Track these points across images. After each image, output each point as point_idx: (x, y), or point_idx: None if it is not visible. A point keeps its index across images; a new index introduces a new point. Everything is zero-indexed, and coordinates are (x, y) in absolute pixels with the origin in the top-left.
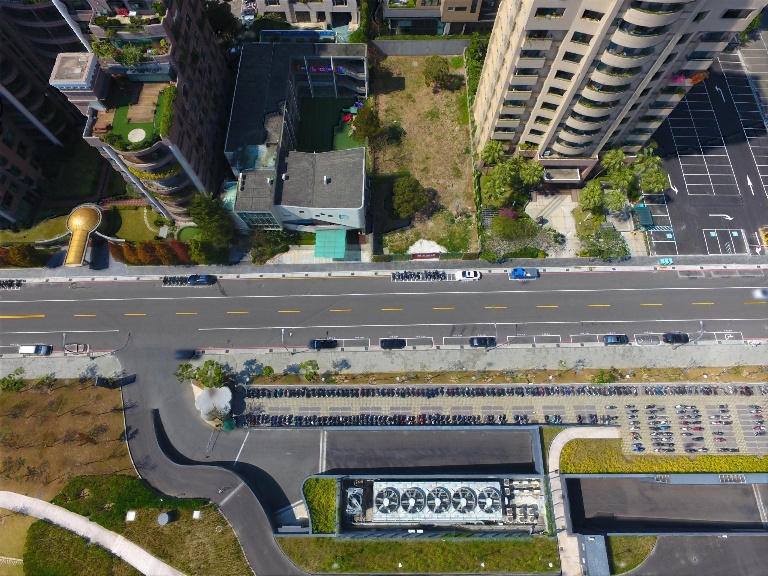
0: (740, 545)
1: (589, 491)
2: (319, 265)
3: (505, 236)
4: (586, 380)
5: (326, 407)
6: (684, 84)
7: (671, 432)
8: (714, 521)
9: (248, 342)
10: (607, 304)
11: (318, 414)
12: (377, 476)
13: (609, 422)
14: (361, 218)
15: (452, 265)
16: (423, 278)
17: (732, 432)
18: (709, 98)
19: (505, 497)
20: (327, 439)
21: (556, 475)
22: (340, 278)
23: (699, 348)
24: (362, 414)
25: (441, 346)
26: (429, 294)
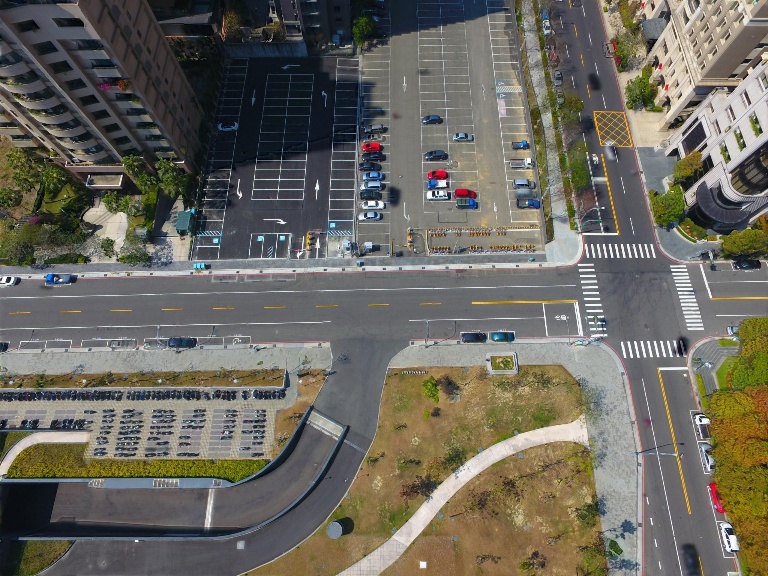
0: (154, 550)
1: (62, 495)
2: None
3: None
4: (73, 385)
5: None
6: (123, 91)
7: (139, 436)
8: (160, 526)
9: None
10: (129, 309)
11: None
12: None
13: (82, 427)
14: None
15: None
16: None
17: (199, 436)
18: (311, 103)
19: None
20: None
21: None
22: None
23: (202, 352)
24: None
25: None
26: None
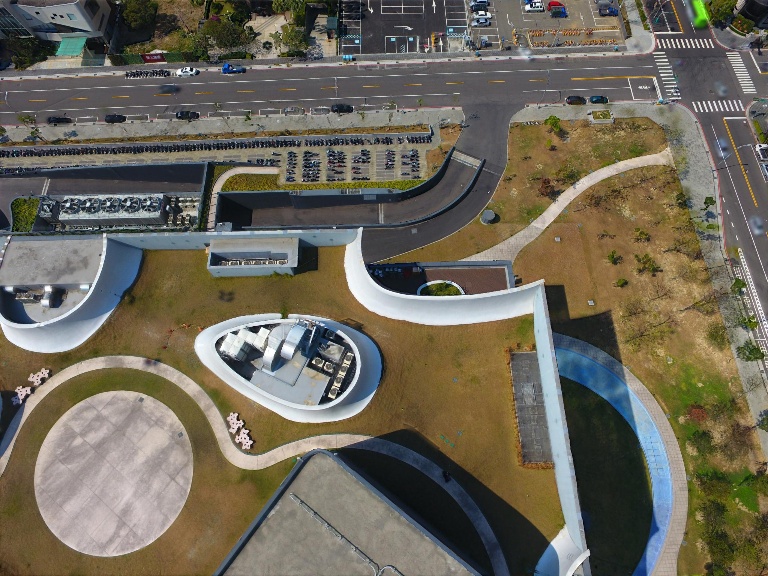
0: None
1: (257, 219)
2: (69, 69)
3: (211, 36)
4: (260, 136)
5: (52, 162)
6: None
7: (319, 169)
8: None
9: (0, 122)
10: (294, 88)
11: (45, 167)
12: (72, 195)
13: (272, 164)
14: (87, 18)
15: (177, 66)
16: (151, 75)
17: (368, 168)
18: None
19: (167, 205)
20: (50, 184)
21: (217, 195)
22: (84, 77)
23: (359, 115)
24: (79, 165)
25: (154, 120)
26: (153, 86)
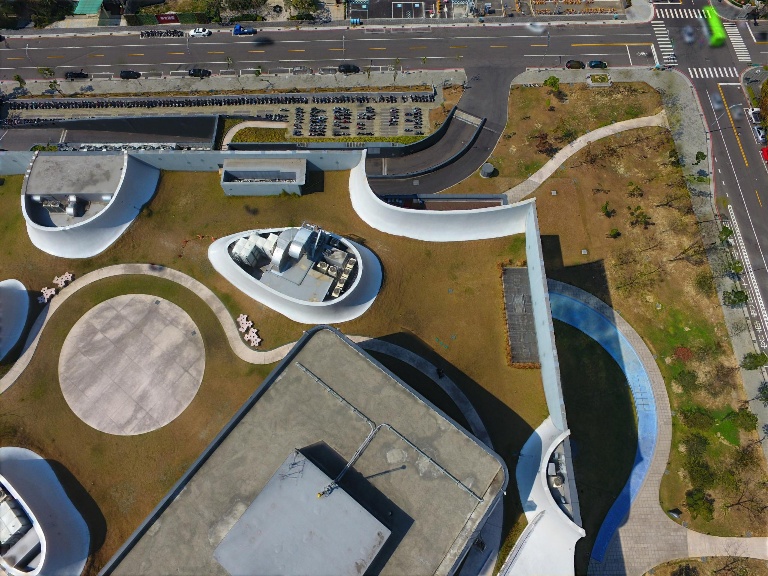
0: None
1: None
2: (86, 28)
3: None
4: None
5: (69, 114)
6: None
7: (326, 125)
8: None
9: None
10: (303, 49)
11: (62, 118)
12: (88, 143)
13: (280, 119)
14: None
15: (190, 27)
16: (165, 35)
17: (372, 124)
18: None
19: None
20: (66, 135)
21: (227, 147)
22: (101, 36)
23: (365, 76)
24: (95, 117)
25: (167, 77)
26: (167, 45)
